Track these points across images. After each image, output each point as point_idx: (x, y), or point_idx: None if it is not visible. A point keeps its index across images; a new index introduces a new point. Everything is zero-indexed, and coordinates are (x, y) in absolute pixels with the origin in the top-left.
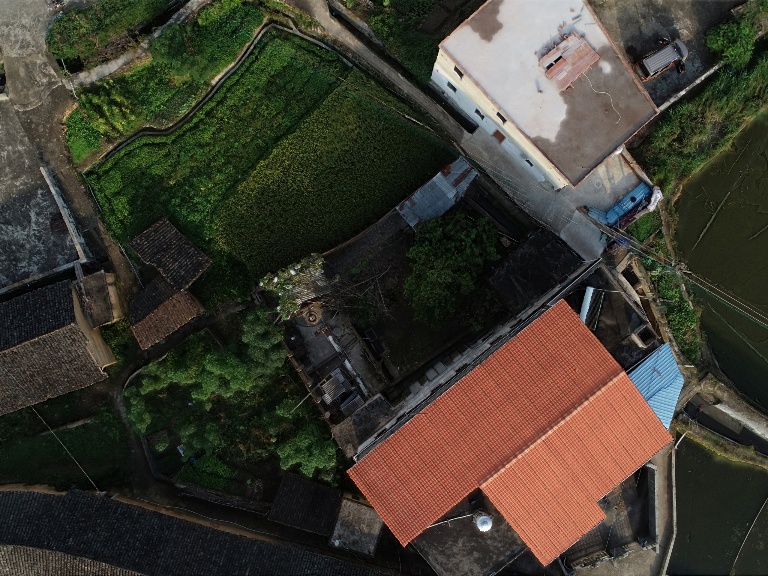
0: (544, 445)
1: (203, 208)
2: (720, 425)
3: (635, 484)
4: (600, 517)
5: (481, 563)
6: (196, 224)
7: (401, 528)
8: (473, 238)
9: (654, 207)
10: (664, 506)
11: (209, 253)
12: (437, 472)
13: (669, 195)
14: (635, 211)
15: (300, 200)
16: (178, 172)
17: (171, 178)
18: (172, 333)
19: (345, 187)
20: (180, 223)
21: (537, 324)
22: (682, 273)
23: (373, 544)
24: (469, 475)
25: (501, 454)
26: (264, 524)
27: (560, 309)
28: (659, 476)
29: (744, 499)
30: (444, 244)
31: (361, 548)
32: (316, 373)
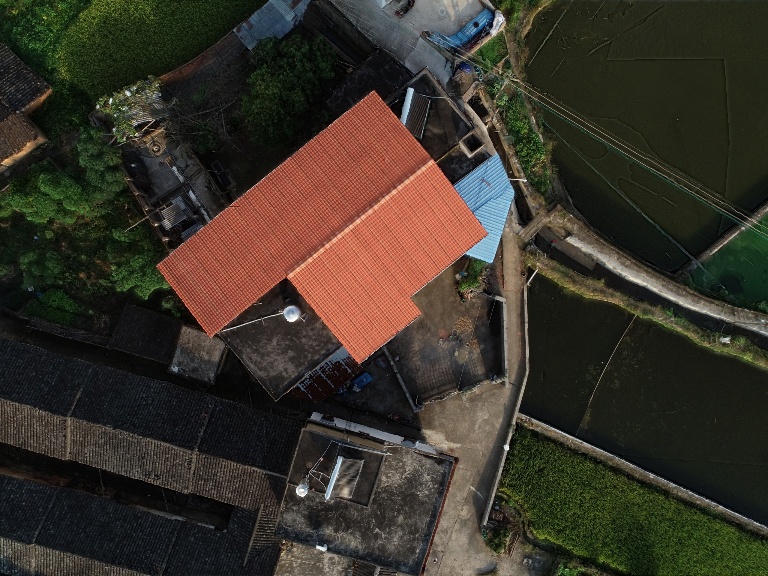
0: (352, 235)
1: (45, 37)
2: (573, 261)
3: (488, 321)
4: (414, 314)
5: (296, 362)
6: (38, 53)
7: (208, 319)
8: (307, 56)
9: (496, 31)
10: (517, 344)
11: (52, 83)
12: (245, 263)
13: (517, 26)
14: (478, 37)
15: (142, 28)
16: (20, 0)
17: (14, 7)
18: (17, 165)
19: (187, 15)
20: (22, 52)
21: (348, 116)
22: (510, 81)
23: (213, 371)
24: (277, 266)
25: (309, 244)
26: (113, 361)
27: (371, 101)
28: (512, 313)
29: (599, 338)
30: (278, 62)
31: (201, 376)
32: (159, 203)
